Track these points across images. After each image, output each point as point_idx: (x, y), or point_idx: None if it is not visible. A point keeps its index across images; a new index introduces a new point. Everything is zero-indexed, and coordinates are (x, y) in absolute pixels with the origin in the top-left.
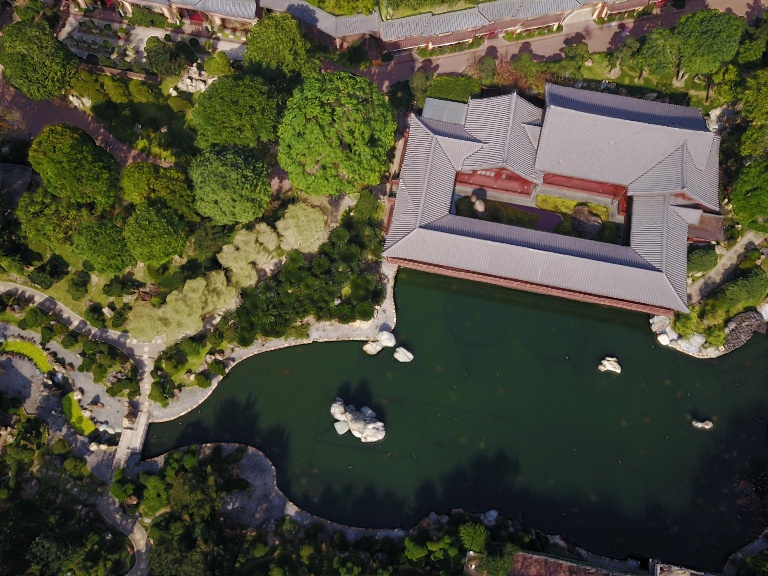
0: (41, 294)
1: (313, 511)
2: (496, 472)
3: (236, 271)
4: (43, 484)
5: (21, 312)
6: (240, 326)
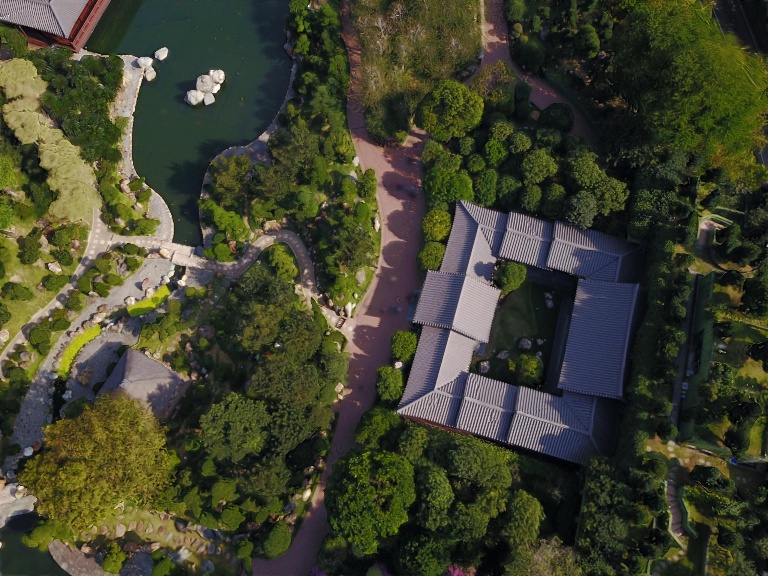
0: (16, 337)
1: (269, 123)
2: (265, 8)
3: (45, 137)
4: (205, 323)
5: (30, 355)
6: (101, 157)
